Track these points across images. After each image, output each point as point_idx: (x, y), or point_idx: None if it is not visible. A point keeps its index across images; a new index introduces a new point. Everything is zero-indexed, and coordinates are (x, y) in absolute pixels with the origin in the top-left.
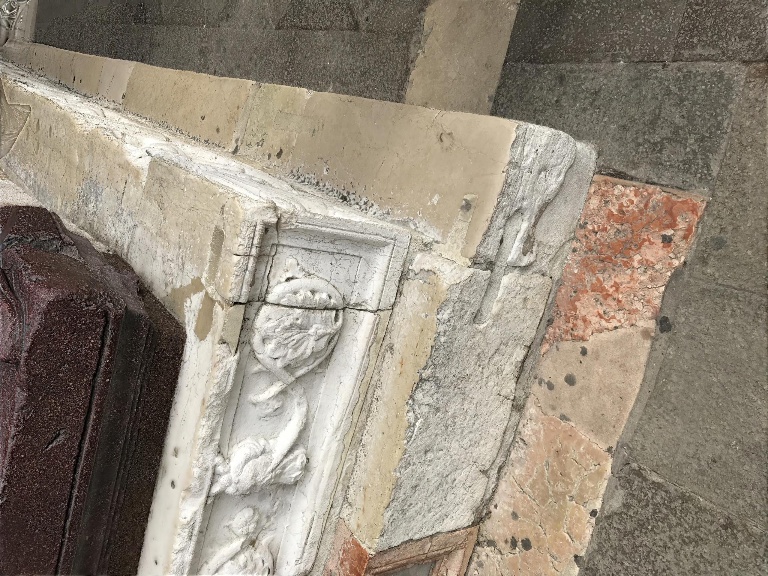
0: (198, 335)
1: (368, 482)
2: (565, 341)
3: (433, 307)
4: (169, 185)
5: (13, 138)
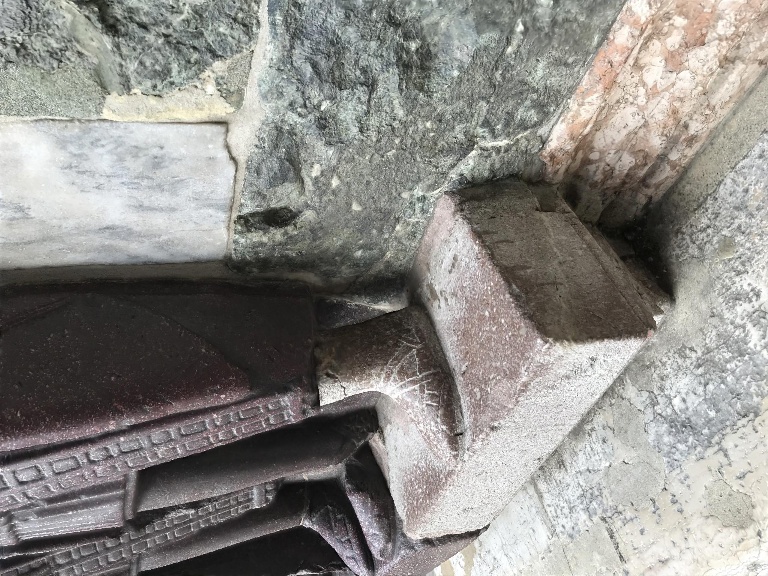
0: None
1: None
2: None
3: None
4: None
5: None
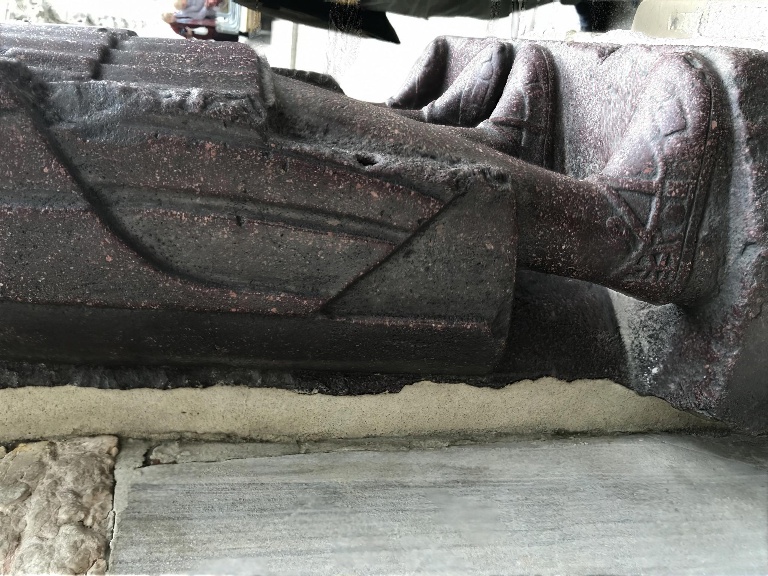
0: None
1: None
2: None
3: (727, 1)
4: None
5: None
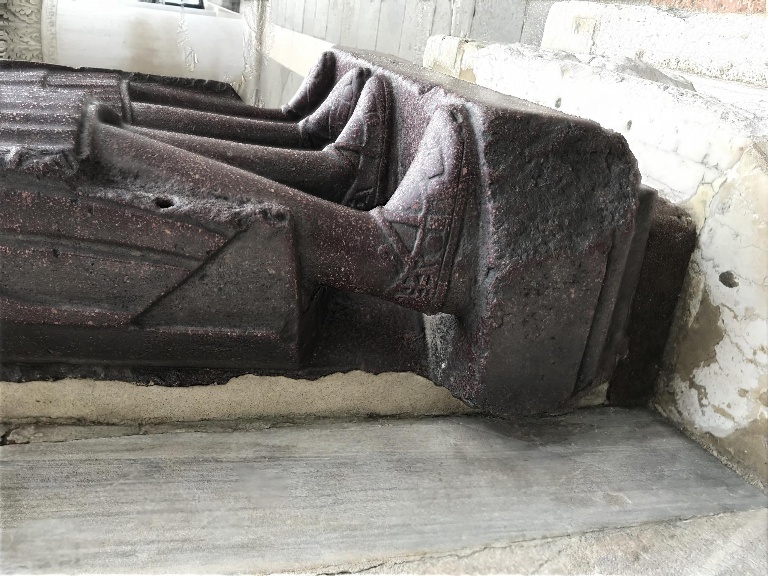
0: None
1: (760, 52)
2: (765, 6)
3: (615, 13)
4: None
5: (271, 3)
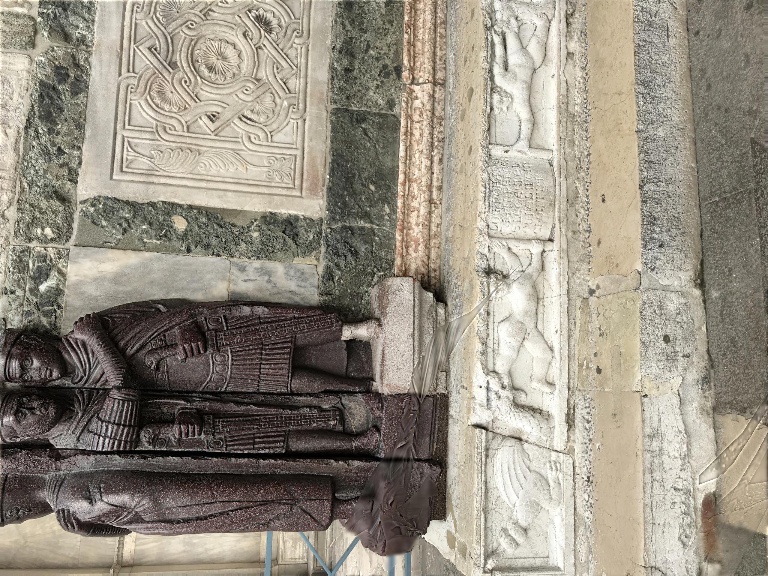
0: (447, 535)
1: None
2: None
3: None
4: (470, 471)
5: None
